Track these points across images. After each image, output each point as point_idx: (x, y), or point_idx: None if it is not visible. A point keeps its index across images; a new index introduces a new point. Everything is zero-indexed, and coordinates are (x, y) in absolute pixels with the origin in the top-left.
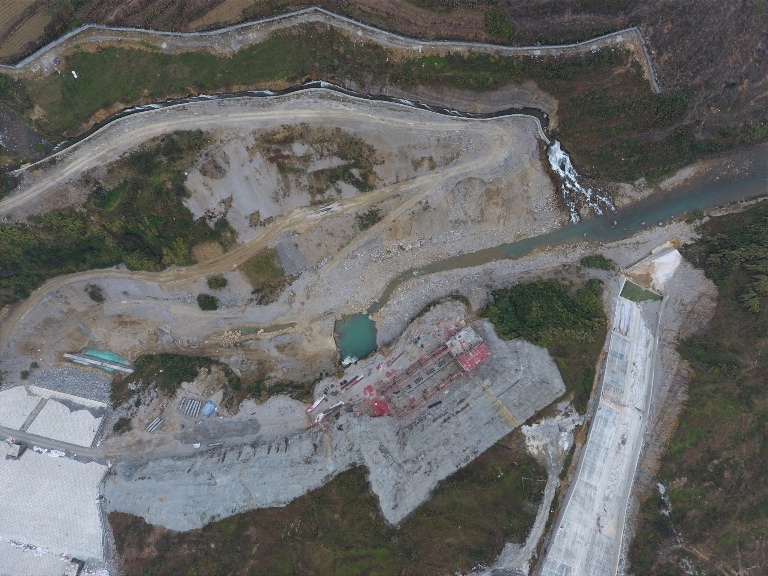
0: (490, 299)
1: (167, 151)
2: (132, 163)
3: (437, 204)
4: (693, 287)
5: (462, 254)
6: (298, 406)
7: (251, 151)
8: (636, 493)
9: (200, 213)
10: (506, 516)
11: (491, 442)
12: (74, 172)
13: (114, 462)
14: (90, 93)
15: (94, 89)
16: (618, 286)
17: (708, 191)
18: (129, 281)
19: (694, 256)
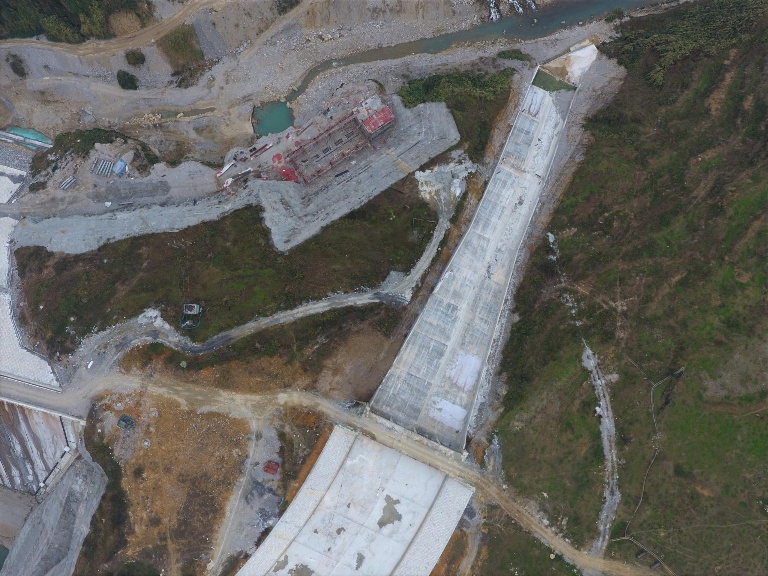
0: None
1: None
2: None
3: None
4: (605, 75)
5: (381, 47)
6: (208, 171)
7: None
8: (528, 245)
9: None
10: (393, 249)
11: (385, 186)
12: None
13: None
14: None
15: None
16: (531, 74)
17: None
18: (49, 52)
19: (609, 48)
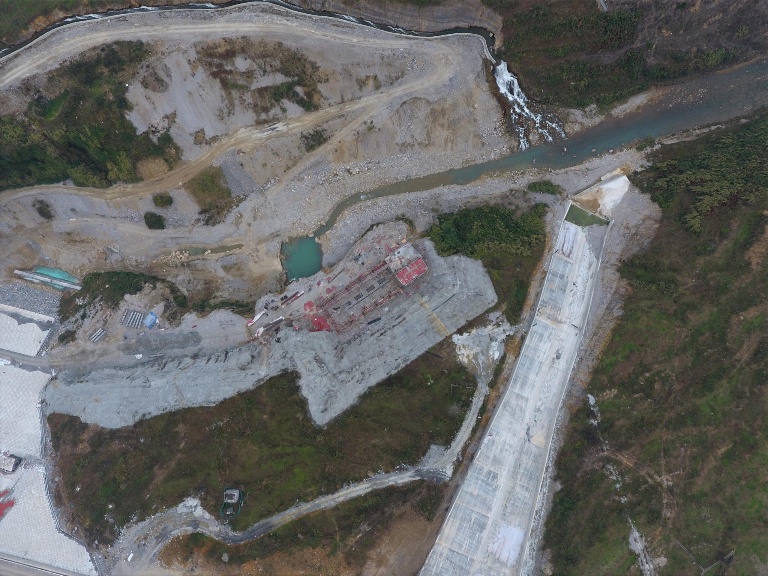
0: (435, 222)
1: (108, 61)
2: (72, 72)
3: (382, 124)
4: (639, 211)
5: (410, 179)
6: (239, 320)
7: (193, 65)
8: (567, 405)
9: (143, 128)
10: (433, 420)
11: (422, 350)
12: (14, 79)
13: (58, 371)
14: None
15: None
16: (563, 210)
17: (661, 119)
18: (76, 197)
19: (642, 181)
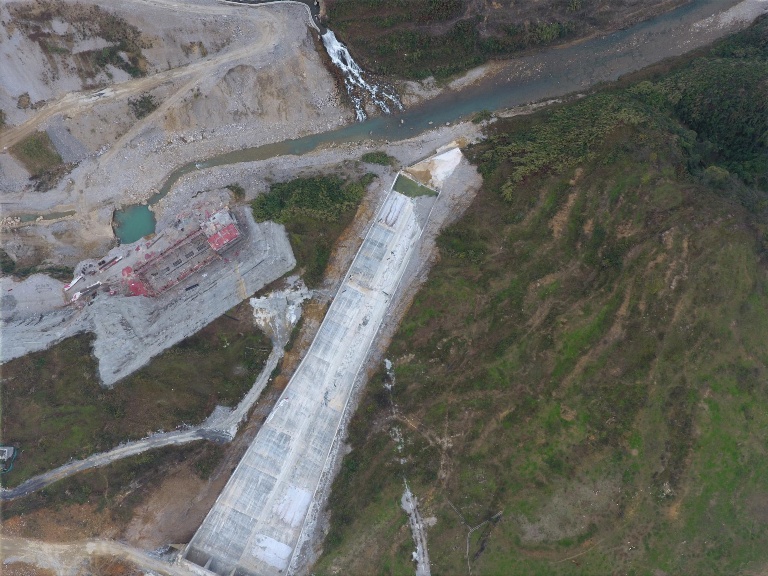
0: (267, 191)
1: None
2: None
3: (209, 91)
4: (465, 182)
5: (245, 148)
6: (55, 284)
7: (8, 27)
8: (367, 370)
9: None
10: (222, 381)
11: (219, 313)
12: None
13: None
14: None
15: None
16: (392, 180)
17: (499, 93)
18: None
19: (472, 153)
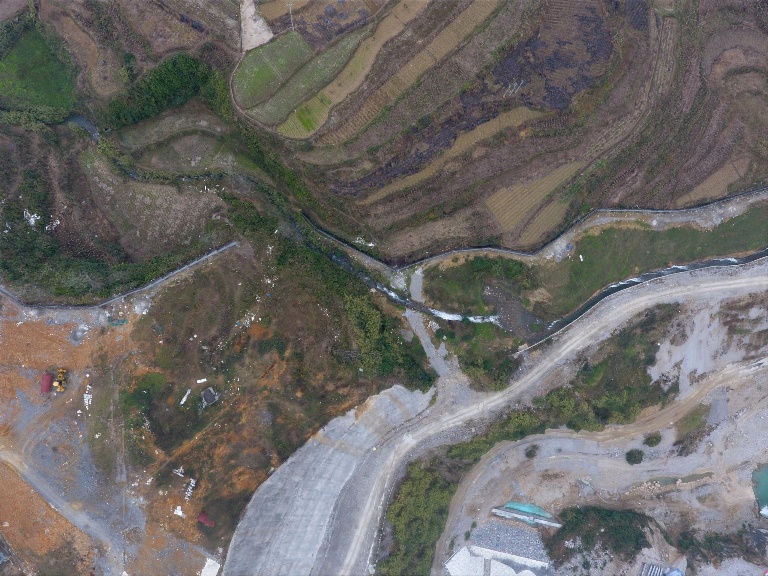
0: None
1: (647, 325)
2: None
3: None
4: None
5: None
6: (755, 570)
7: (713, 317)
8: None
9: (656, 377)
10: None
11: None
12: (570, 352)
13: None
14: (592, 275)
15: (596, 271)
16: None
17: None
18: (569, 440)
19: None
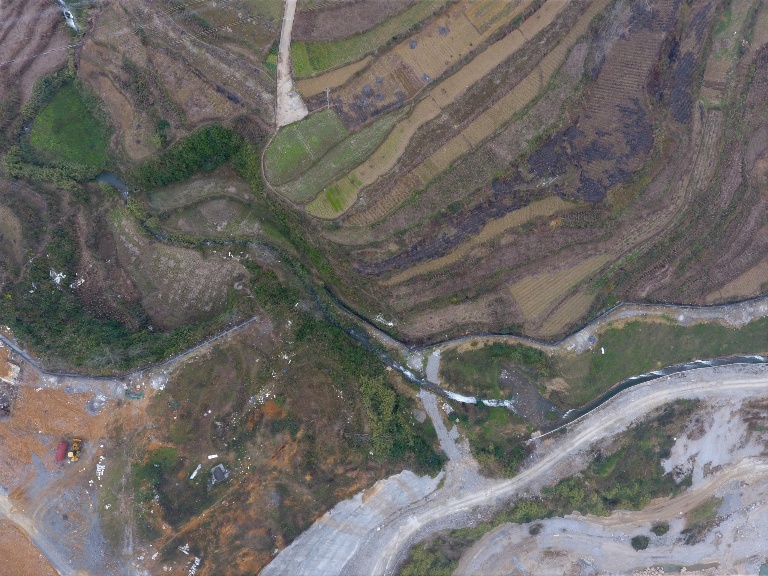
0: None
1: (665, 419)
2: None
3: None
4: None
5: None
6: None
7: (733, 414)
8: None
9: (669, 469)
10: None
11: None
12: (583, 442)
13: None
14: (612, 368)
15: (617, 364)
16: None
17: None
18: (575, 522)
19: None
